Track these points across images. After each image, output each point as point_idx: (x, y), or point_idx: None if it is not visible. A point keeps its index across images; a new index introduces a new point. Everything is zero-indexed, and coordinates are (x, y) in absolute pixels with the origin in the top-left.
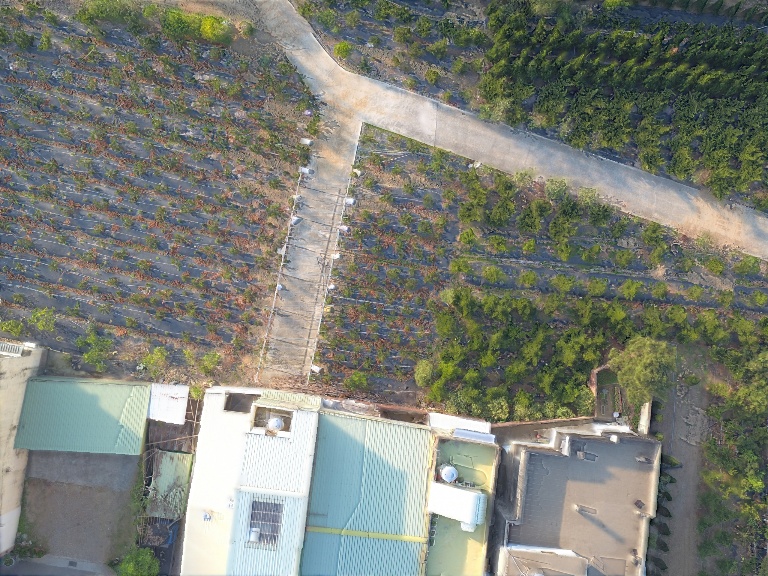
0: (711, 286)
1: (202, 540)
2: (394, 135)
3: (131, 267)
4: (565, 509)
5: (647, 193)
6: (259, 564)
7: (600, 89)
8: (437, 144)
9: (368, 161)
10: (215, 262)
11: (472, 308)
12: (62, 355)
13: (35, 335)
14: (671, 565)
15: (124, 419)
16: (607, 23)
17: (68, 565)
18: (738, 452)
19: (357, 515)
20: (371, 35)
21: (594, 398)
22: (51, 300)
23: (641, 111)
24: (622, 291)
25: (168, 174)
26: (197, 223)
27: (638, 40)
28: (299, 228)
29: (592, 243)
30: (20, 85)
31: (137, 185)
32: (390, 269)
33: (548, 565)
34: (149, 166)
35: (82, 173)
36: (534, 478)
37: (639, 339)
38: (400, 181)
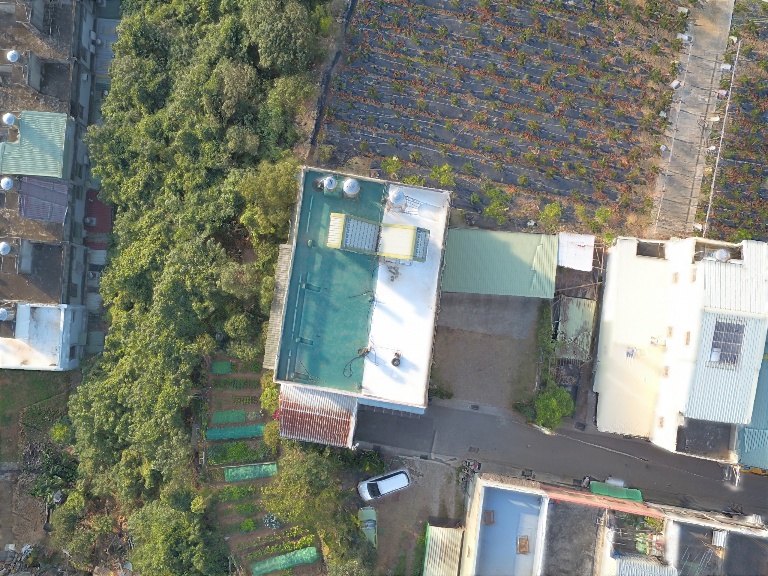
0: None
1: (624, 376)
2: (766, 4)
3: (520, 128)
4: None
5: None
6: (718, 383)
7: None
8: None
9: (742, 29)
10: (599, 124)
11: None
12: (456, 211)
13: None
14: None
15: (536, 265)
16: None
17: (470, 408)
18: None
19: None
20: None
21: None
22: (446, 159)
23: None
24: None
25: (552, 41)
26: (581, 87)
27: None
28: (679, 92)
29: None
30: None
31: (523, 51)
32: (767, 131)
33: None
34: (533, 33)
35: (471, 39)
36: None
37: None
38: None
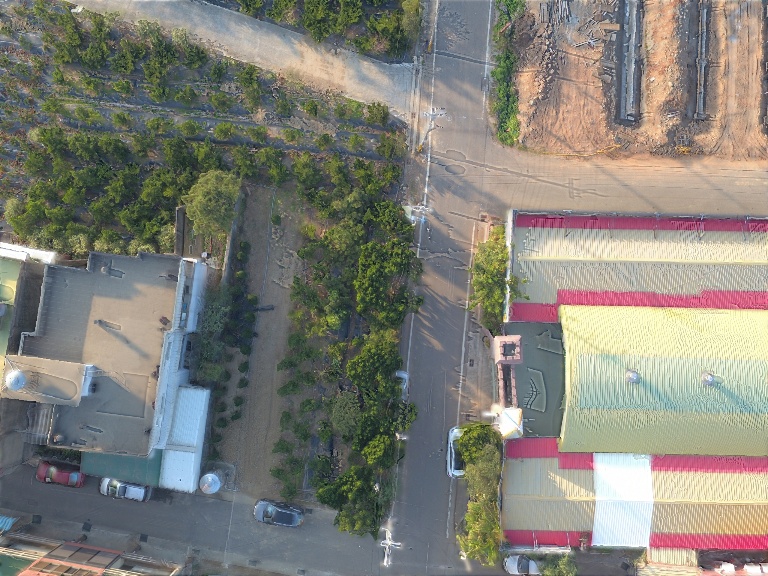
0: (313, 131)
1: None
2: None
3: None
4: (89, 325)
5: (250, 38)
6: None
7: None
8: None
9: None
10: None
11: (56, 145)
12: None
13: None
14: (257, 406)
15: None
16: None
17: None
18: None
19: None
20: None
21: (173, 234)
22: None
23: None
24: None
25: None
26: None
27: None
28: None
29: (194, 87)
30: None
31: None
32: None
33: (44, 370)
34: None
35: None
36: (52, 291)
37: (209, 172)
38: (1, 25)
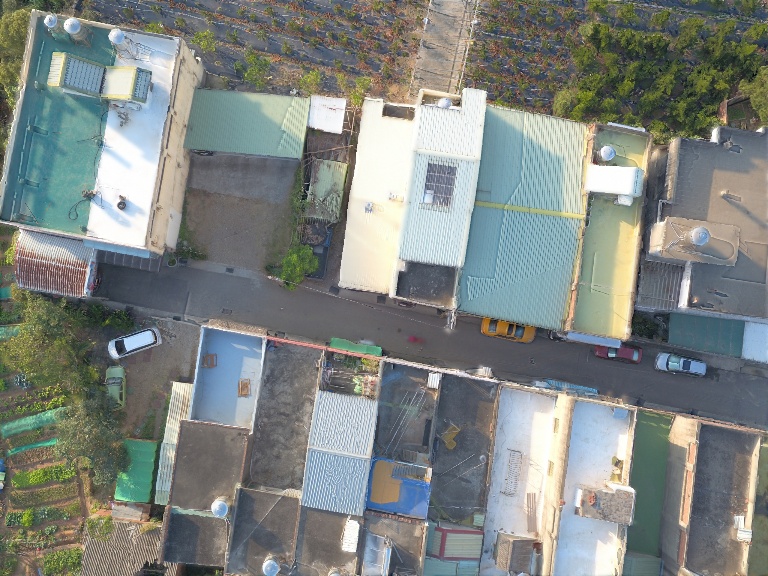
0: None
1: (363, 231)
2: None
3: None
4: (712, 196)
5: None
6: (432, 225)
7: None
8: None
9: None
10: None
11: (610, 40)
12: (220, 79)
13: None
14: None
15: (286, 125)
16: None
17: (225, 271)
18: None
19: (518, 193)
20: None
21: None
22: (210, 27)
23: None
24: (748, 34)
25: None
26: None
27: None
28: None
29: None
30: None
31: None
32: (530, 7)
33: None
34: None
35: None
36: (685, 162)
37: None
38: None
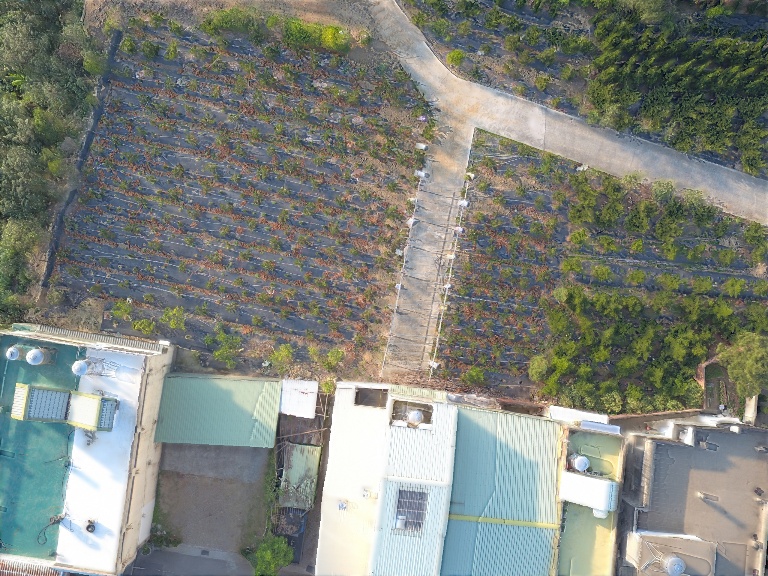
0: None
1: (337, 529)
2: (505, 140)
3: (256, 268)
4: (689, 497)
5: (747, 194)
6: (404, 550)
7: (702, 94)
8: (546, 148)
9: (481, 165)
10: (336, 263)
11: (585, 305)
12: (191, 353)
13: (164, 334)
14: None
15: (257, 413)
16: (707, 31)
17: (201, 554)
18: None
19: (492, 503)
20: (481, 43)
21: (703, 391)
22: (180, 300)
23: (742, 115)
24: (725, 288)
25: (289, 178)
26: (318, 225)
27: (740, 47)
28: (416, 229)
29: (695, 242)
30: (146, 93)
31: (260, 189)
32: (504, 268)
33: (679, 549)
34: (271, 170)
35: (207, 178)
36: (661, 467)
37: (748, 334)
38: (512, 184)
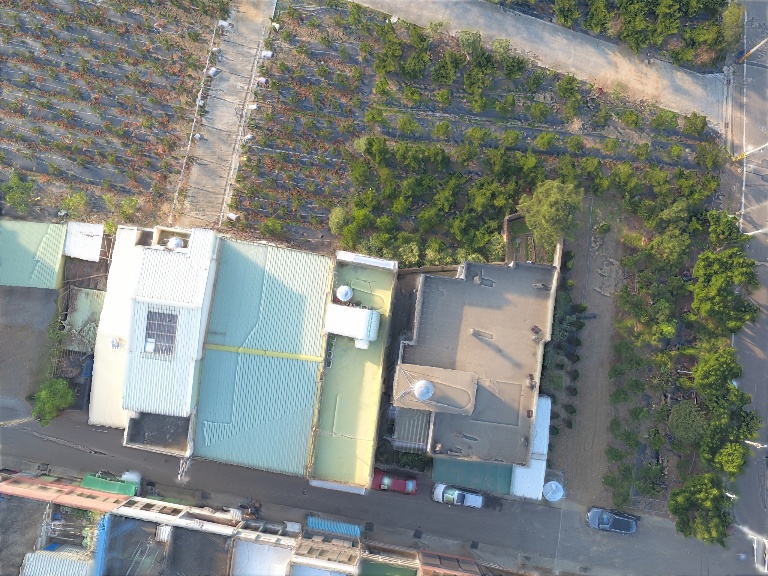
0: (628, 140)
1: (110, 368)
2: None
3: (54, 117)
4: (462, 333)
5: (564, 48)
6: (154, 374)
7: None
8: None
9: (287, 16)
10: (136, 113)
11: (385, 155)
12: None
13: None
14: (583, 413)
15: (40, 255)
16: None
17: None
18: (652, 303)
19: (255, 334)
20: None
21: (504, 243)
22: None
23: None
24: (537, 143)
25: (92, 28)
26: (119, 75)
27: None
28: (218, 80)
29: None
30: None
31: (62, 38)
32: None
33: (438, 379)
34: (74, 20)
35: (9, 27)
36: (429, 300)
37: (548, 182)
38: (318, 35)
